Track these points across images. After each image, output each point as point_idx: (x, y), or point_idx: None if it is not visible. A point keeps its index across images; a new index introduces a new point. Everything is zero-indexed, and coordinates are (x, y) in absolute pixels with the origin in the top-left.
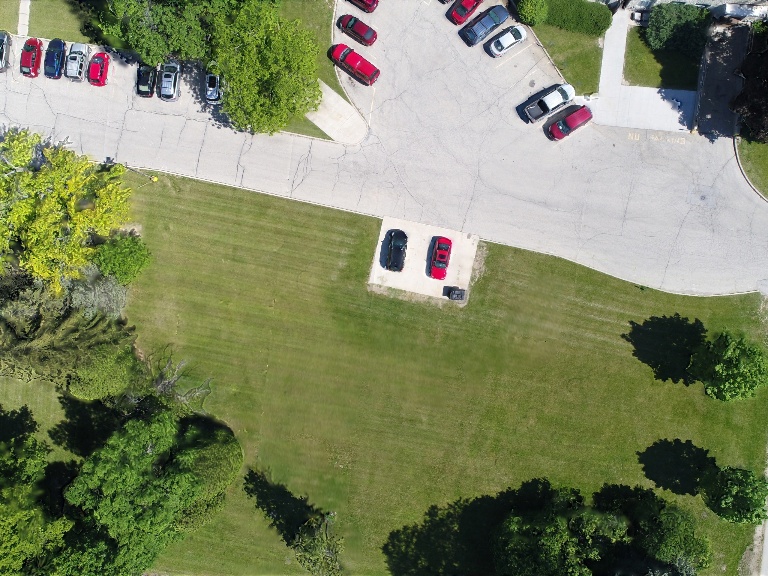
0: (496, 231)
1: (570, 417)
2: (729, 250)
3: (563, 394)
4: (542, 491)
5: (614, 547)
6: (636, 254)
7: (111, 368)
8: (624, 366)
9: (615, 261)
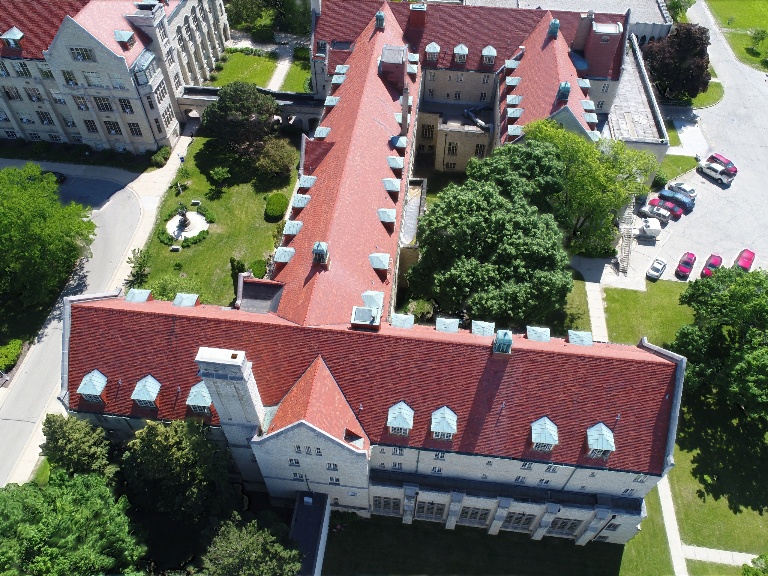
0: None
1: None
2: (759, 111)
3: None
4: None
5: None
6: None
7: None
8: None
9: None
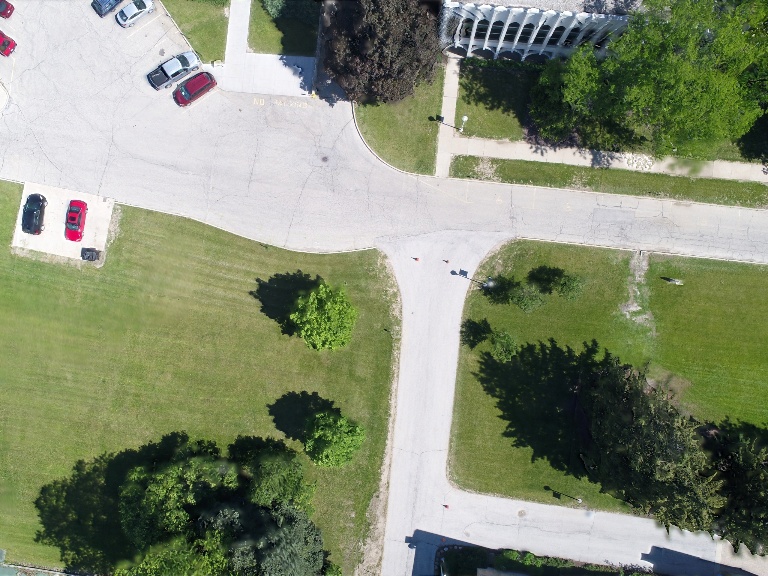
0: (130, 194)
1: (204, 372)
2: (348, 209)
3: (197, 350)
4: (181, 444)
5: (215, 492)
6: (261, 214)
7: None
8: (253, 322)
9: (242, 221)
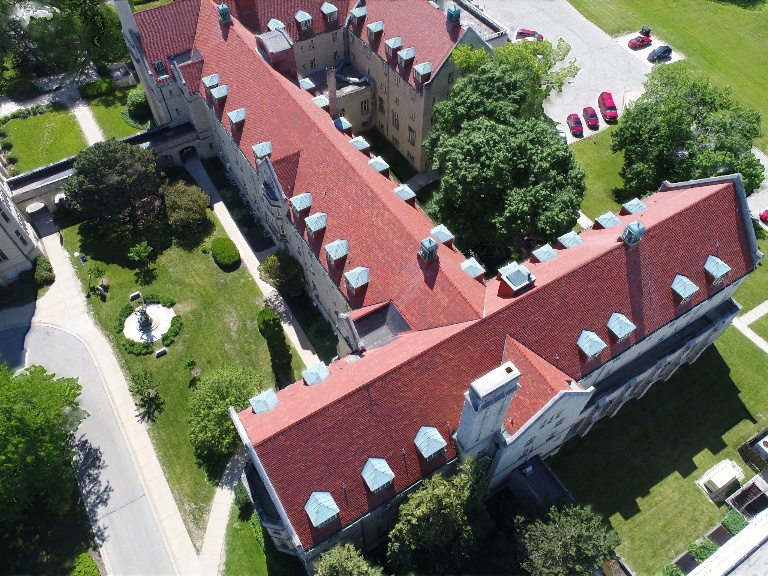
0: (602, 36)
1: None
2: None
3: None
4: None
5: None
6: (550, 1)
7: None
8: None
9: None
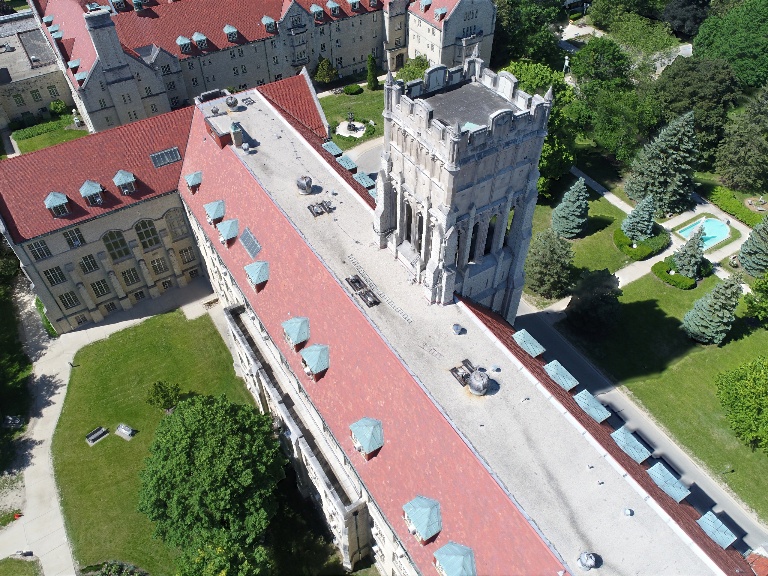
0: None
1: None
2: None
3: None
4: None
5: None
6: None
7: None
8: None
9: None
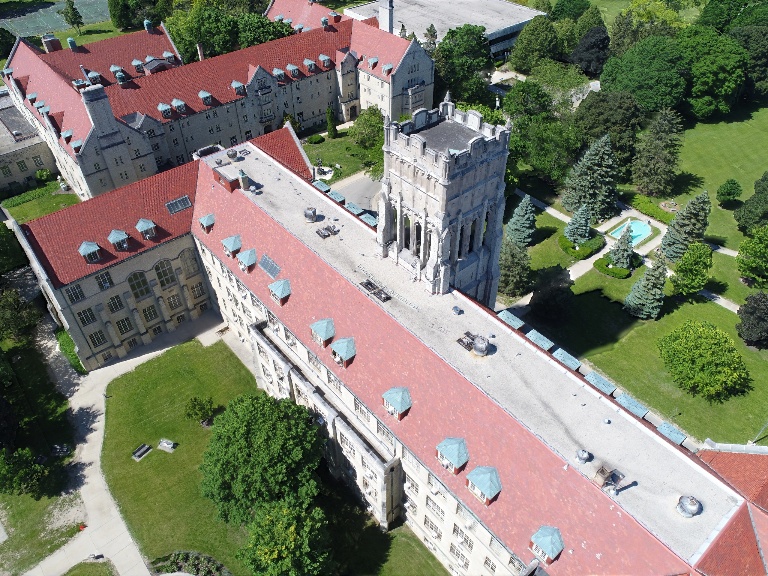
0: None
1: None
2: None
3: None
4: None
5: None
6: None
7: (160, 5)
8: None
9: None
